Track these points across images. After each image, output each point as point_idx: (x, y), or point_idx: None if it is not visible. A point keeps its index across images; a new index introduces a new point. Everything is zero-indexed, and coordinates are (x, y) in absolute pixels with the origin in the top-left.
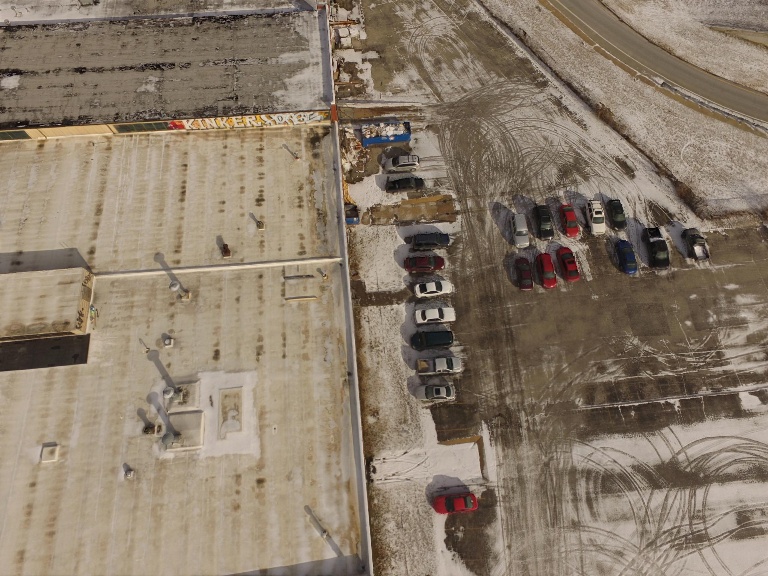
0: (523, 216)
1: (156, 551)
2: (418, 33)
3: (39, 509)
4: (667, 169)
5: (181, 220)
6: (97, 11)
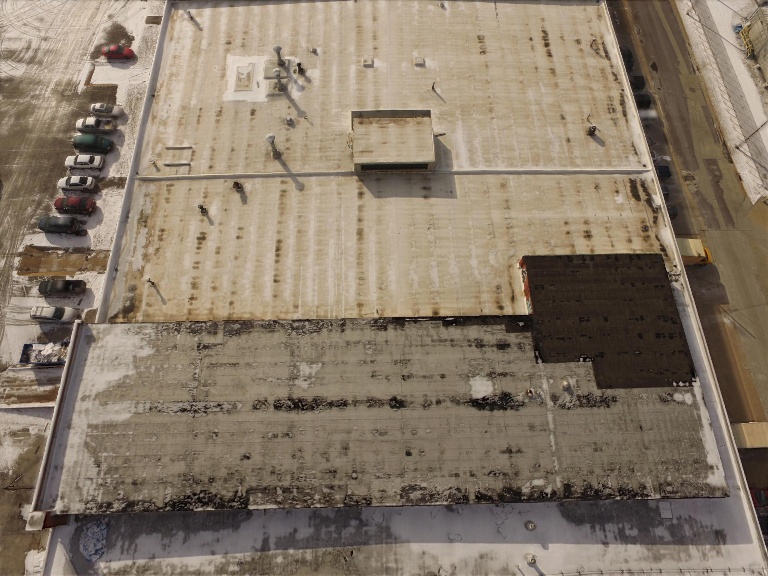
0: None
1: (295, 17)
2: None
3: (369, 37)
4: None
5: (280, 221)
6: (410, 560)
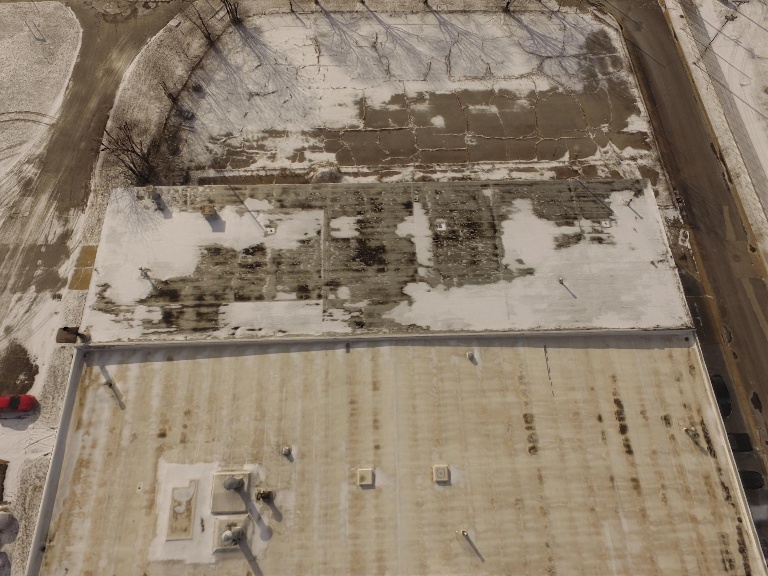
0: None
1: (260, 382)
2: None
3: (367, 424)
4: None
5: None
6: None
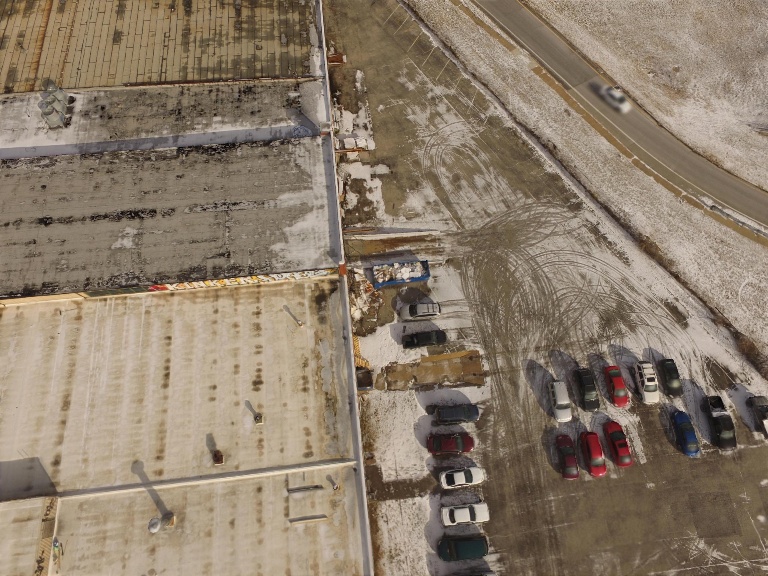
0: (564, 385)
1: None
2: (433, 142)
3: None
4: (725, 317)
5: (164, 414)
6: (67, 135)
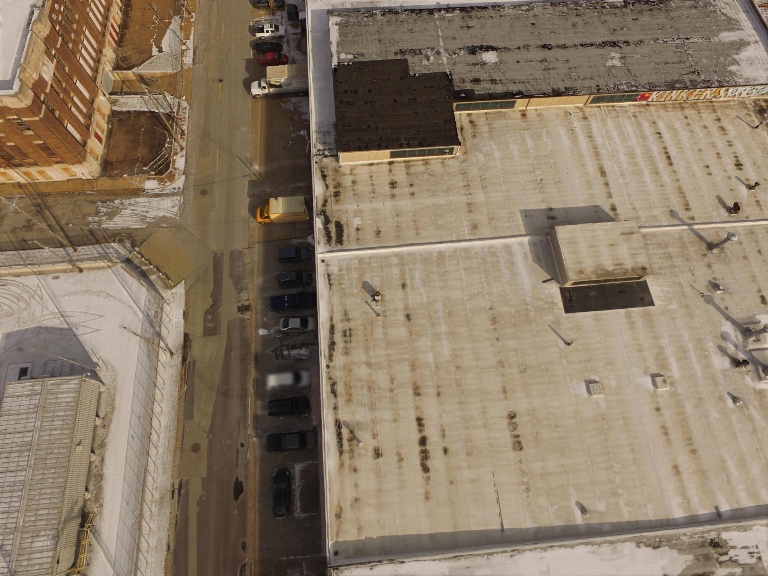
0: None
1: None
2: None
3: (673, 430)
4: None
5: (678, 182)
6: None
